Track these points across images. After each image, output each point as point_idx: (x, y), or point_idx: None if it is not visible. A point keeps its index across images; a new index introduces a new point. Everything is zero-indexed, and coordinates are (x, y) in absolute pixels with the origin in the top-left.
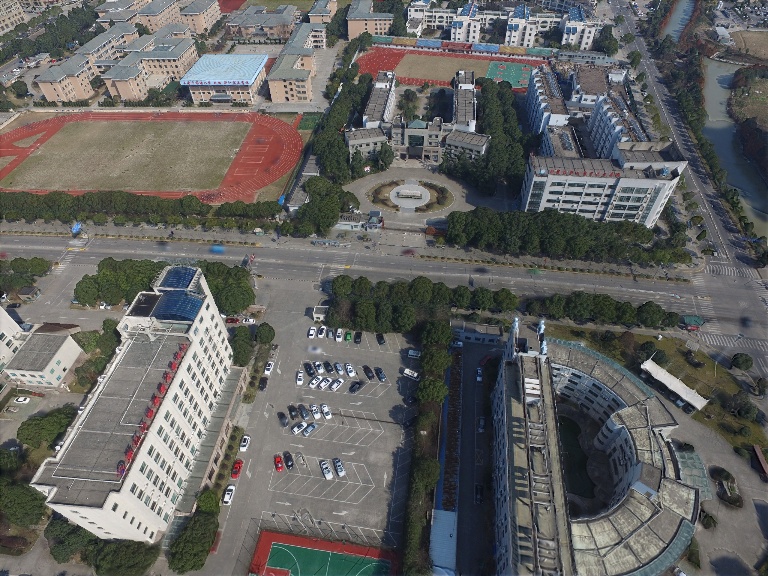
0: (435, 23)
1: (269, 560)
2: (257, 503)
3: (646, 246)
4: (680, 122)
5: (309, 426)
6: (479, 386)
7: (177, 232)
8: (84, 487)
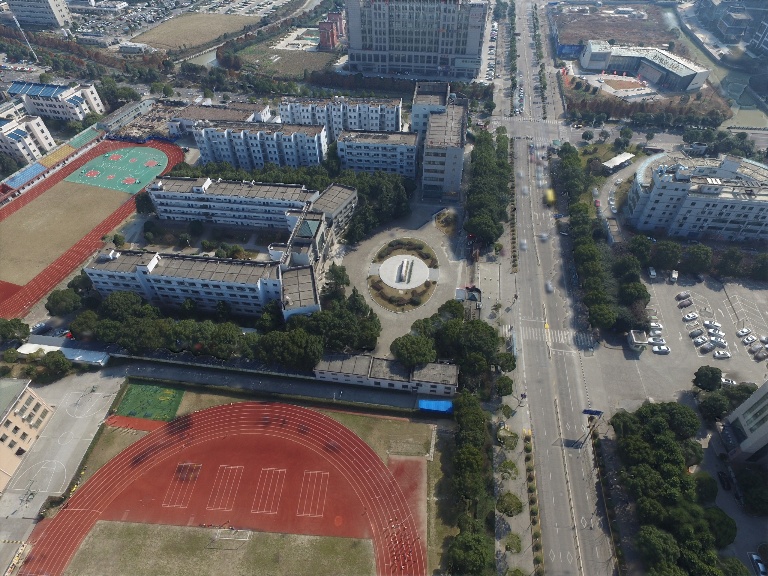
0: None
1: None
2: None
3: None
4: None
5: None
6: None
7: None
8: None
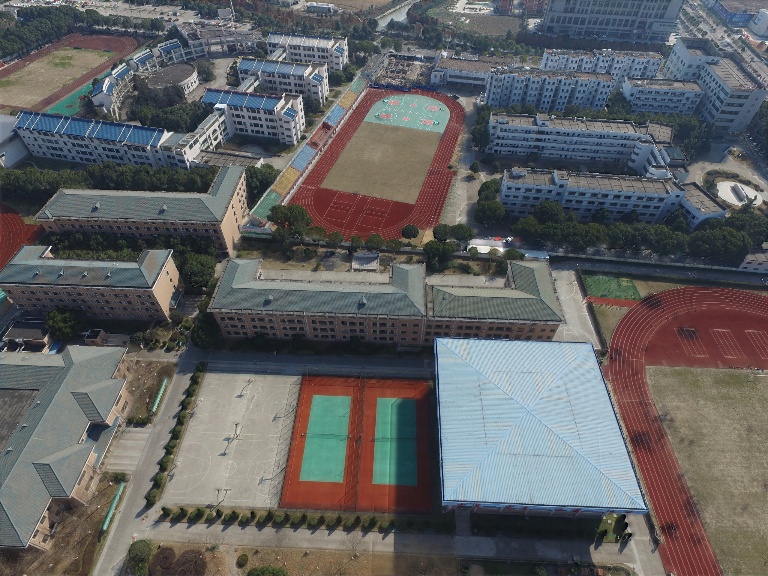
0: (212, 145)
1: None
2: None
3: None
4: (514, 56)
5: None
6: None
7: None
8: None
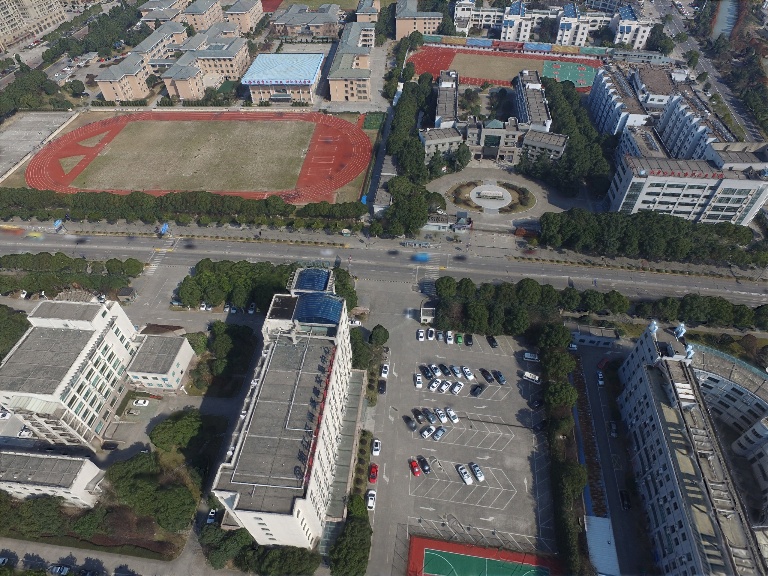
0: (482, 22)
1: (425, 566)
2: (401, 508)
3: (742, 248)
4: (749, 122)
5: (439, 430)
6: (602, 390)
7: (262, 233)
8: (267, 493)
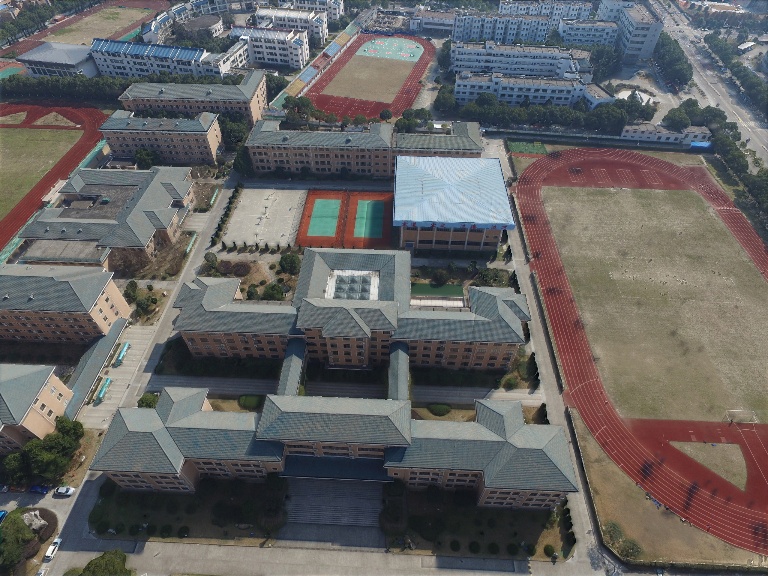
0: (238, 66)
1: None
2: None
3: None
4: None
5: None
6: None
7: None
8: None
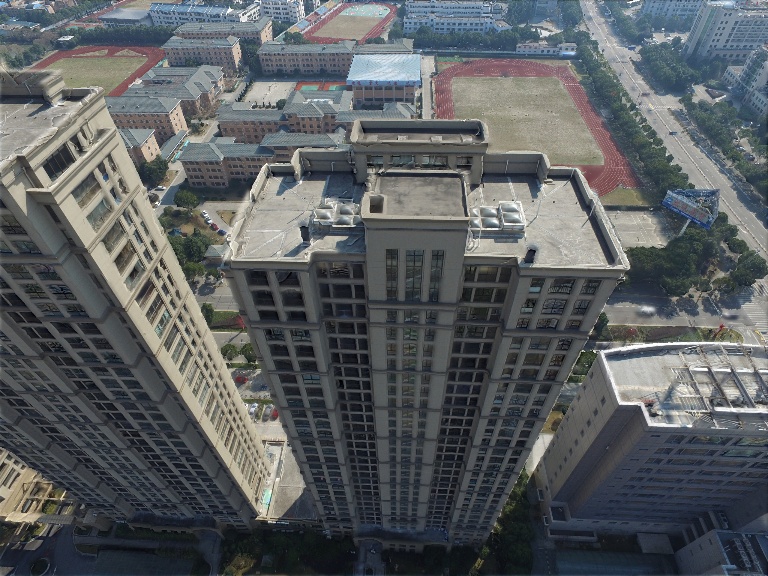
0: None
1: None
2: None
3: None
4: None
5: None
6: None
7: None
8: None
